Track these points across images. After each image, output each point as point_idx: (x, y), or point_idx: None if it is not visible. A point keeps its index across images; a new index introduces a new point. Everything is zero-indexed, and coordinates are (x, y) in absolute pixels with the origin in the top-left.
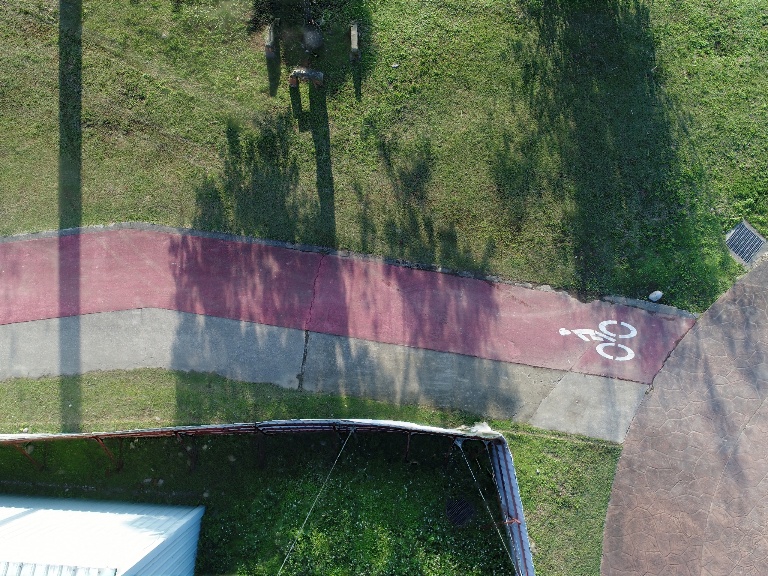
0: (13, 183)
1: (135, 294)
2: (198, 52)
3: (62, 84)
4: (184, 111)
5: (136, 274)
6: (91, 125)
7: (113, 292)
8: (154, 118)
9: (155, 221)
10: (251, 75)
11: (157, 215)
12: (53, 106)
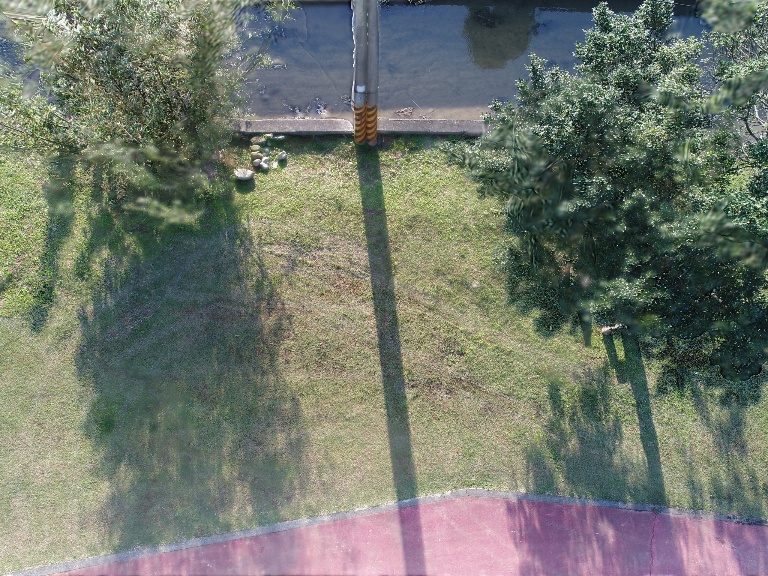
0: (346, 452)
1: (480, 567)
2: (509, 301)
3: (381, 343)
4: (504, 366)
5: (478, 545)
6: (414, 385)
7: (458, 566)
8: (475, 375)
9: (489, 486)
10: (563, 323)
11: (490, 479)
12: (375, 367)
